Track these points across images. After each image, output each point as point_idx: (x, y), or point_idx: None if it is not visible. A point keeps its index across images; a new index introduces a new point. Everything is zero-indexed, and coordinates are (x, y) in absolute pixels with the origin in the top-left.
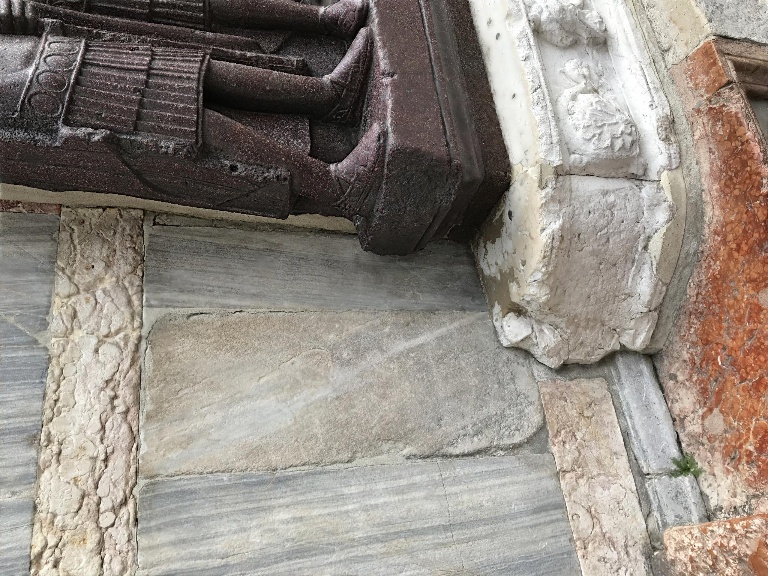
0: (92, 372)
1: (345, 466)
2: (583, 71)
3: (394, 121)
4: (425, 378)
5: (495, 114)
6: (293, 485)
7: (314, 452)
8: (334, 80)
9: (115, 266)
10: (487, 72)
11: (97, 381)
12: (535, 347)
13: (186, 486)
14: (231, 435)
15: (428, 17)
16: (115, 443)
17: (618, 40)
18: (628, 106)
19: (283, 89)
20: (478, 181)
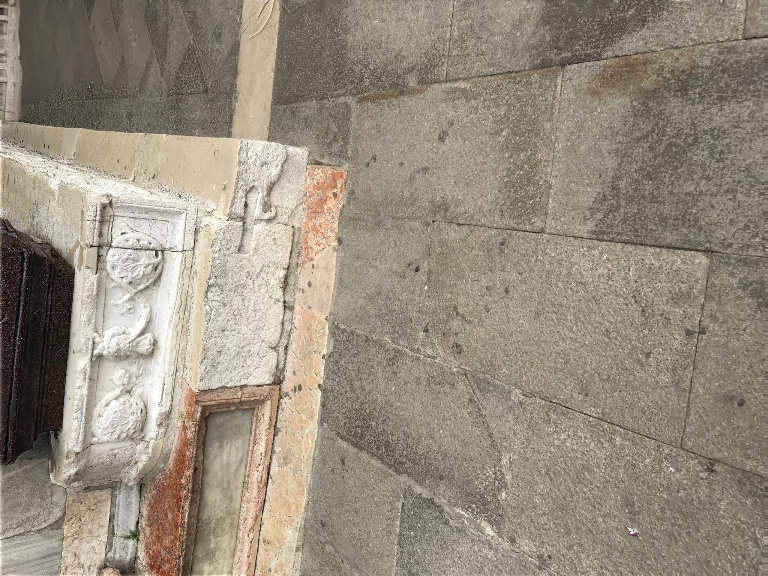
0: None
1: None
2: (124, 381)
3: None
4: None
5: (64, 389)
6: None
7: None
8: None
9: None
10: (68, 358)
11: None
12: None
13: None
14: None
15: (19, 354)
16: None
17: (161, 352)
18: (148, 398)
19: None
20: None
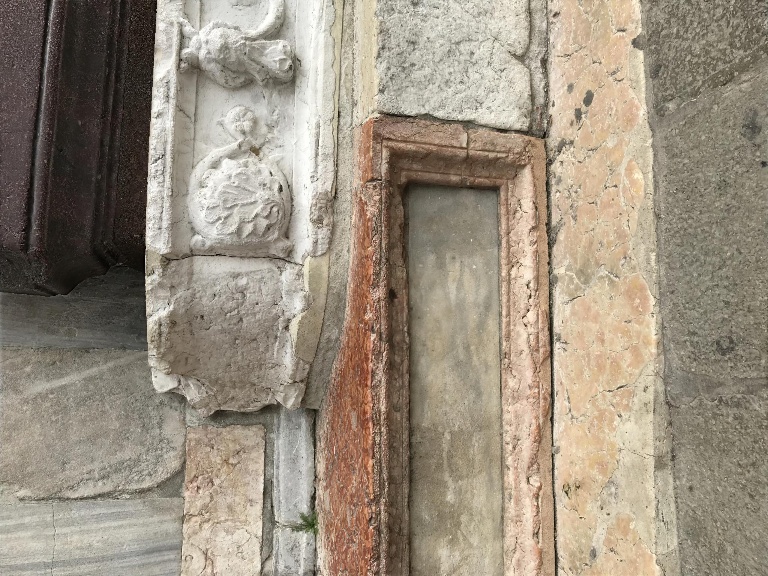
0: None
1: None
2: (243, 126)
3: None
4: (60, 420)
5: None
6: None
7: None
8: None
9: None
10: None
11: None
12: (186, 396)
13: None
14: None
15: (53, 48)
16: None
17: (308, 80)
18: (293, 170)
19: None
20: (86, 255)
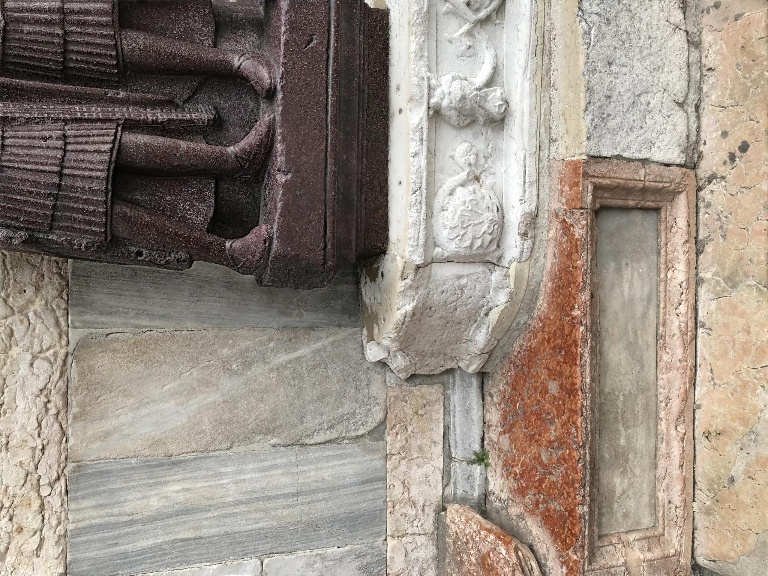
0: (29, 383)
1: (224, 452)
2: (470, 159)
3: (280, 228)
4: (297, 385)
5: (386, 183)
6: (184, 466)
7: (202, 443)
8: (238, 155)
9: (44, 290)
10: (389, 135)
11: (33, 390)
12: (390, 363)
13: (103, 468)
14: (138, 431)
15: (333, 99)
16: (49, 437)
17: (515, 119)
18: (503, 193)
19: (190, 163)
20: (352, 263)
